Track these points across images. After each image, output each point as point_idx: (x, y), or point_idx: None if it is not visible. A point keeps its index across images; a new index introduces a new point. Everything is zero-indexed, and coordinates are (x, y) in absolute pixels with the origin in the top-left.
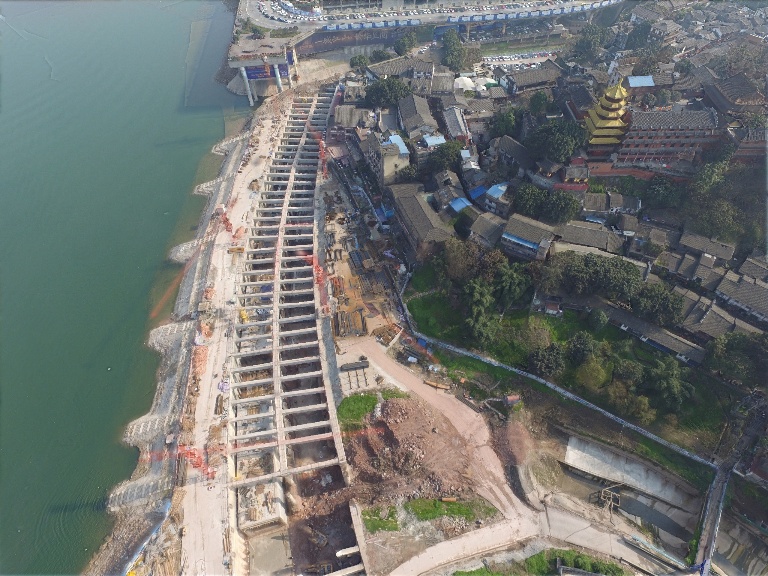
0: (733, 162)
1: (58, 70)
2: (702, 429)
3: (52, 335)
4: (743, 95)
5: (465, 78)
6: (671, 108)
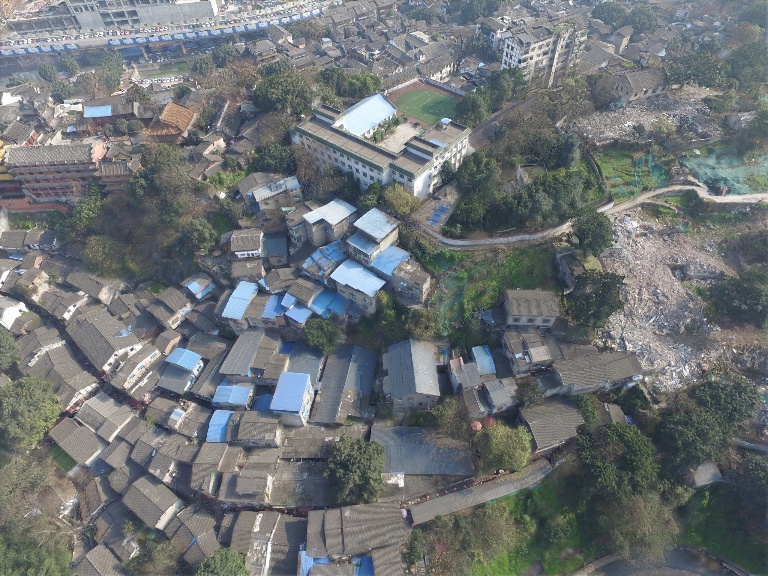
0: (105, 196)
1: None
2: None
3: None
4: (153, 125)
5: (64, 105)
6: (128, 138)
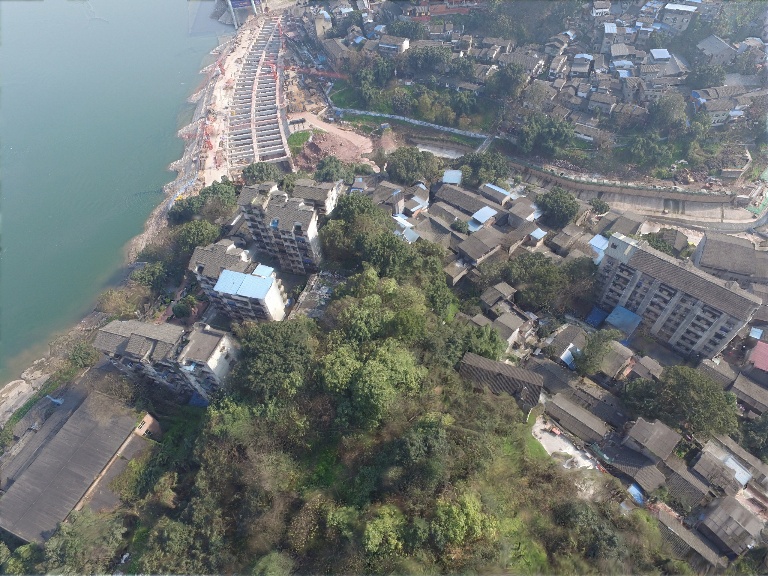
0: None
1: (99, 17)
2: (484, 125)
3: (120, 137)
4: None
5: None
6: None
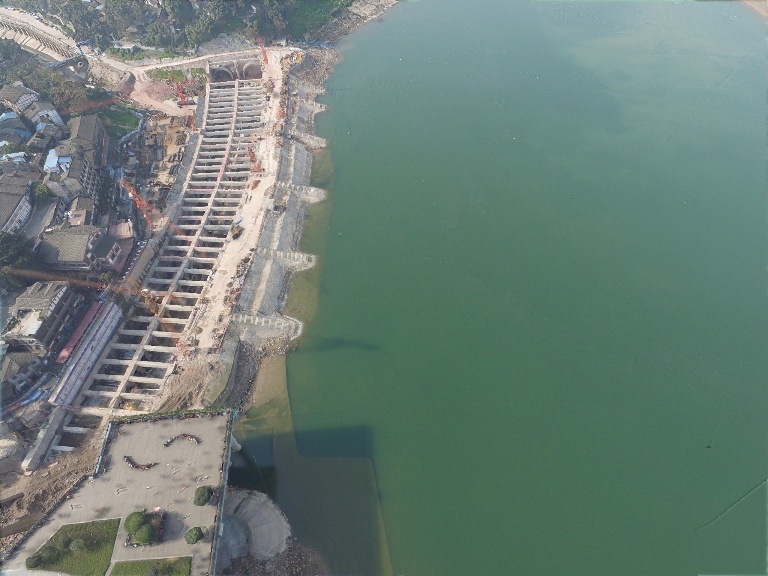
0: None
1: (700, 567)
2: None
3: (394, 146)
4: None
5: None
6: None
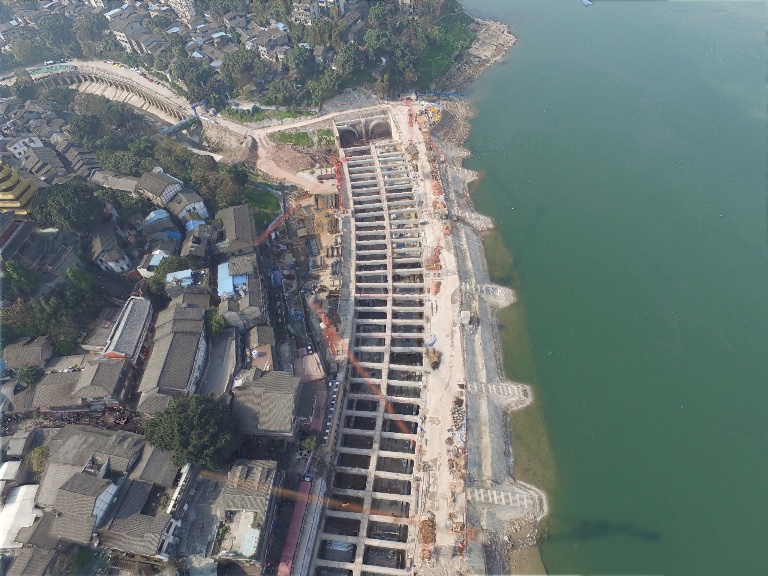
0: None
1: None
2: None
3: (575, 226)
4: None
5: None
6: None
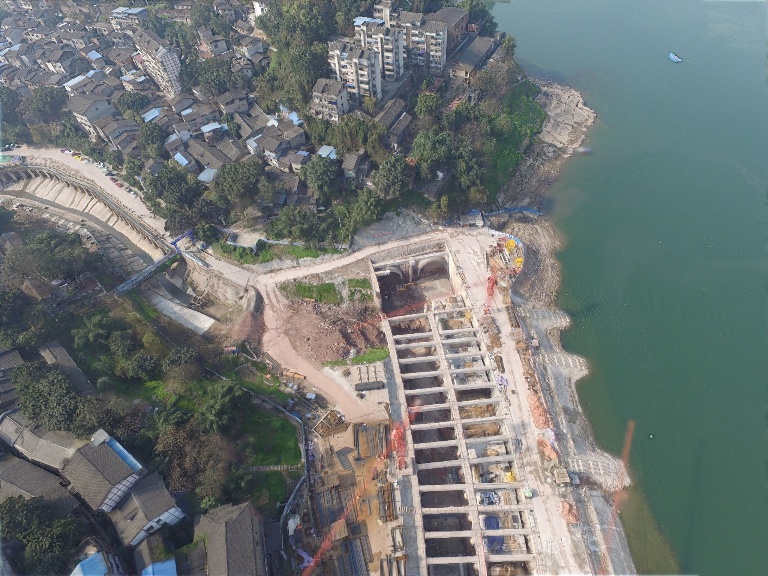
0: None
1: None
2: None
3: (762, 486)
4: None
5: None
6: None
